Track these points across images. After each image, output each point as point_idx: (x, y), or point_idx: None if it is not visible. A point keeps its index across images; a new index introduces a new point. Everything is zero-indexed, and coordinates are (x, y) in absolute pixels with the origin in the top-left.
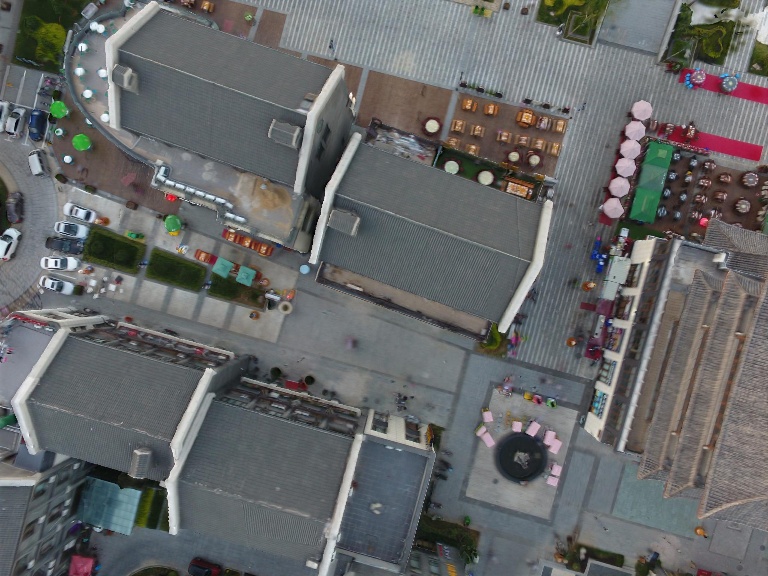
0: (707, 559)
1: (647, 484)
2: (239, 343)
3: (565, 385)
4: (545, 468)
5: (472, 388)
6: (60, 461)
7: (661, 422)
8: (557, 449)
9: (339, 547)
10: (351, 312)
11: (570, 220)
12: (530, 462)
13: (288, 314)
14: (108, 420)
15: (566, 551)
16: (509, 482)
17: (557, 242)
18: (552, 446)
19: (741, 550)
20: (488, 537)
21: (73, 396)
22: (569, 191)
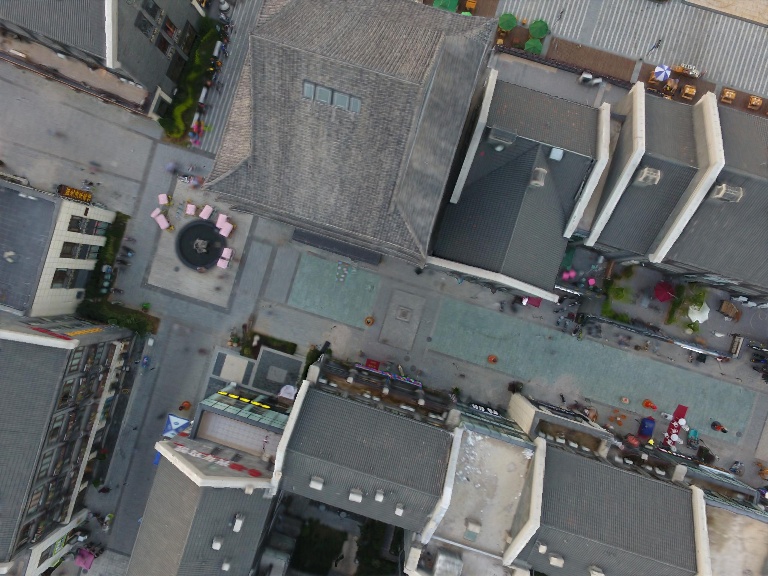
0: (376, 349)
1: (321, 274)
2: None
3: None
4: None
5: (158, 177)
6: None
7: None
8: (227, 232)
9: None
10: (44, 100)
11: None
12: (210, 250)
13: None
14: None
15: (241, 338)
16: (190, 270)
17: (244, 36)
18: (222, 229)
19: (408, 341)
20: (168, 324)
21: None
22: None
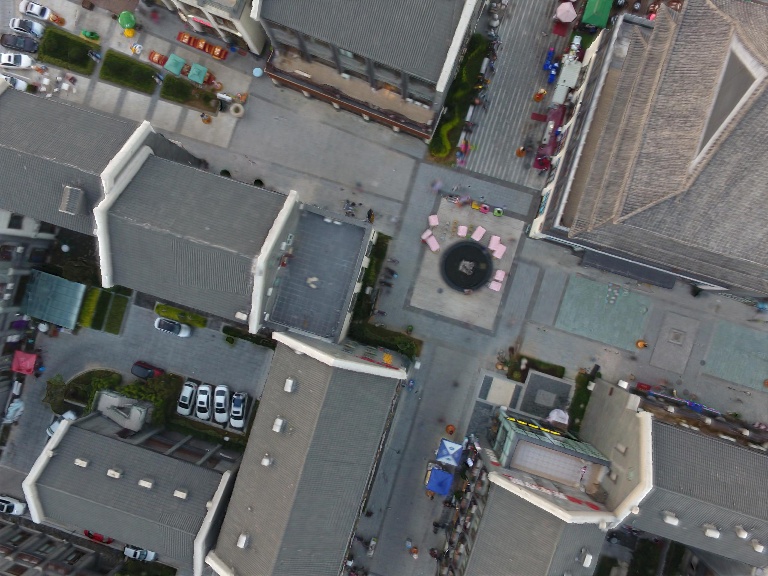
0: (647, 373)
1: (590, 296)
2: (190, 147)
3: (513, 195)
4: (490, 278)
5: (420, 197)
6: (1, 232)
7: (594, 182)
8: (501, 253)
9: (275, 321)
10: (303, 118)
11: (524, 30)
12: (475, 272)
13: (240, 119)
14: (41, 154)
15: (507, 361)
16: (454, 292)
17: (511, 52)
18: (496, 250)
19: (681, 364)
20: (431, 346)
21: (8, 134)
22: (524, 1)
